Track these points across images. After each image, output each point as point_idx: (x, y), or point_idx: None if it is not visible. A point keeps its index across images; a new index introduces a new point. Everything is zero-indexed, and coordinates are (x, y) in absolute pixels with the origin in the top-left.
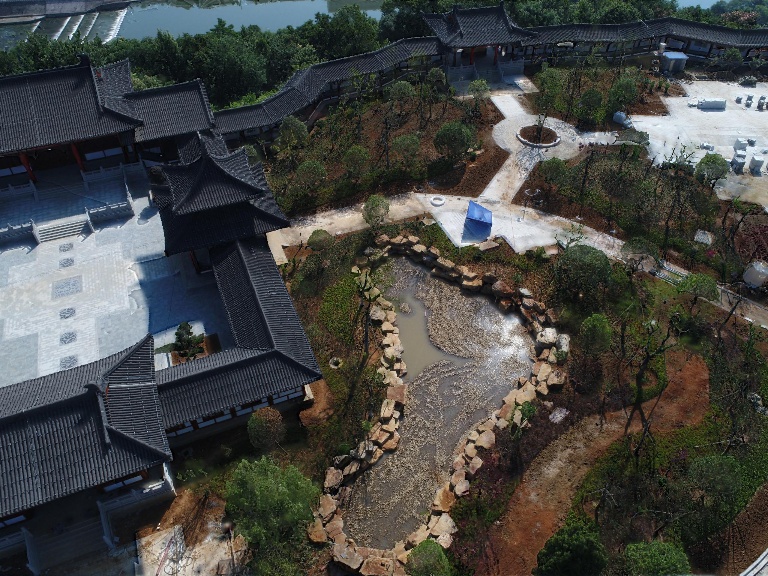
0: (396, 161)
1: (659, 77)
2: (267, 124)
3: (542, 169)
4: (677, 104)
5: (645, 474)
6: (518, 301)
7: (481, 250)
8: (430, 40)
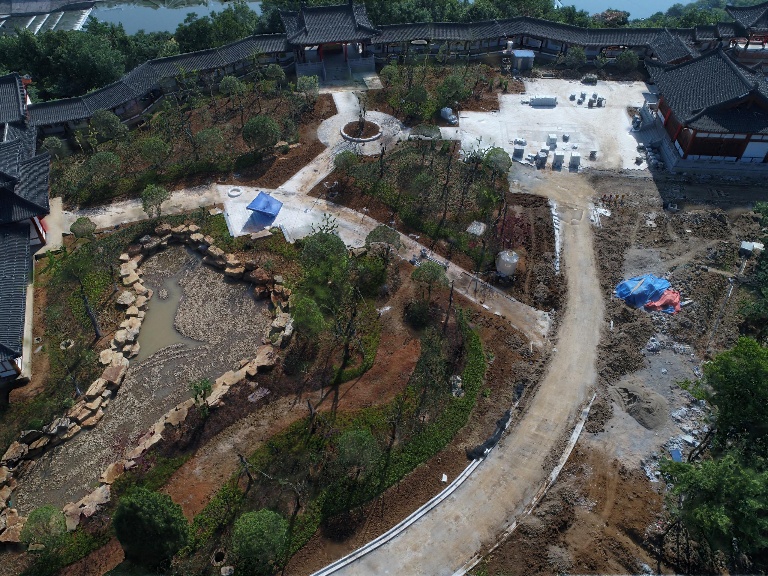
0: (207, 154)
1: (505, 75)
2: (84, 117)
3: (335, 162)
4: (511, 101)
5: (312, 450)
6: (270, 288)
7: (252, 239)
8: (279, 37)
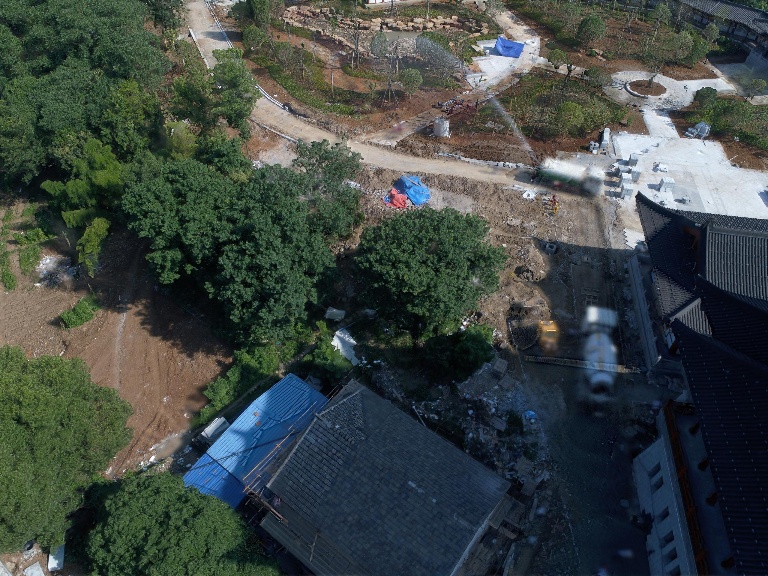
0: None
1: None
2: None
3: None
4: None
5: None
6: None
7: None
8: None
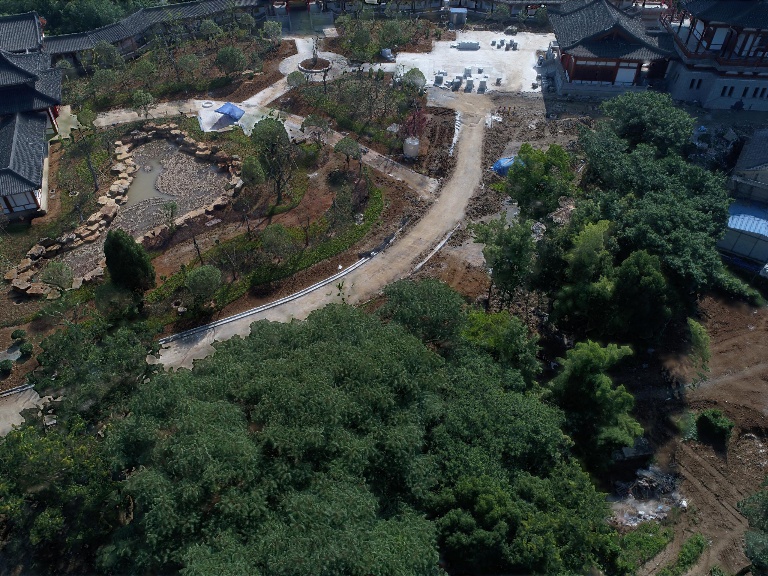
0: (188, 78)
1: (442, 27)
2: (89, 48)
3: None
4: (442, 46)
5: None
6: (229, 163)
7: (218, 132)
8: None
